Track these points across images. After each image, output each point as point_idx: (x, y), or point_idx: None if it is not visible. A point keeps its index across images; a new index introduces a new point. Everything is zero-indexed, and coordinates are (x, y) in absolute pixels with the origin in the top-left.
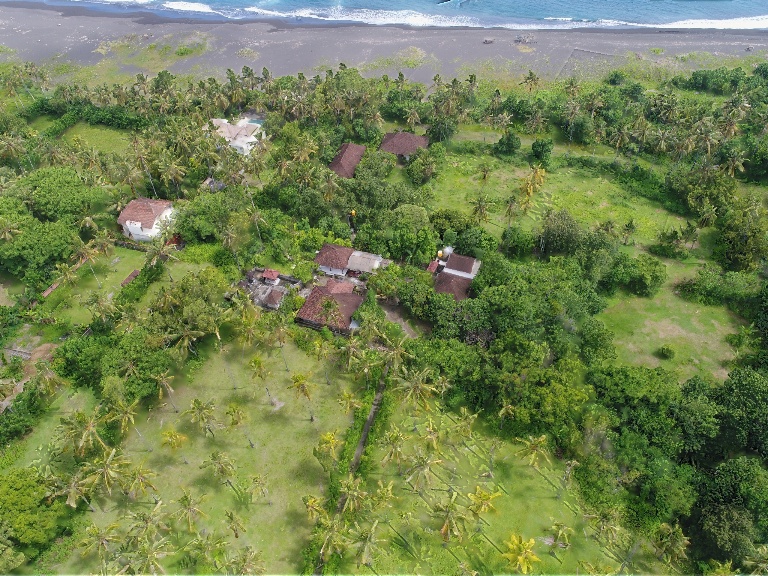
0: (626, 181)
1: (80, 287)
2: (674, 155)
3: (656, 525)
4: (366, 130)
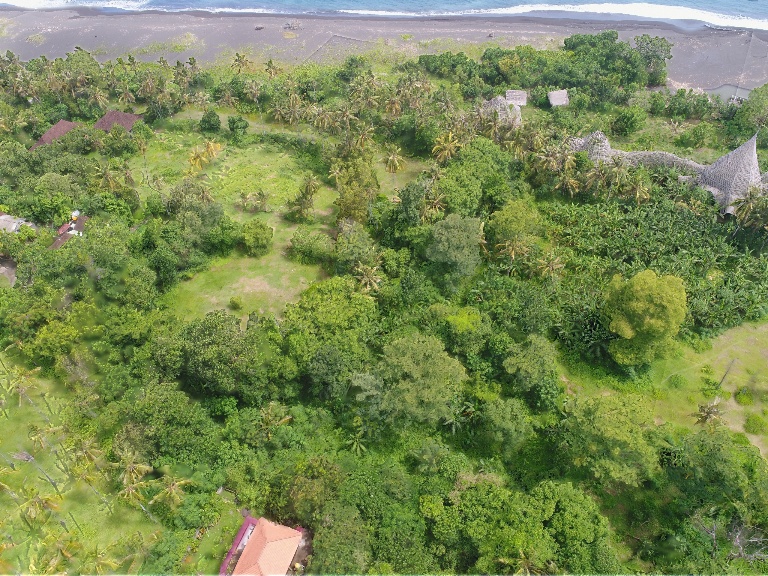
0: (301, 155)
1: None
2: (329, 131)
3: (109, 442)
4: (90, 109)
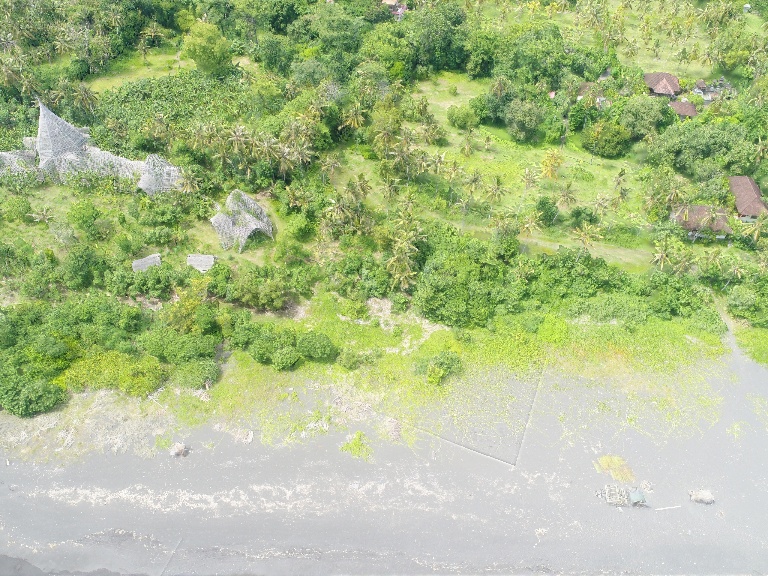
0: None
1: None
2: None
3: None
4: None
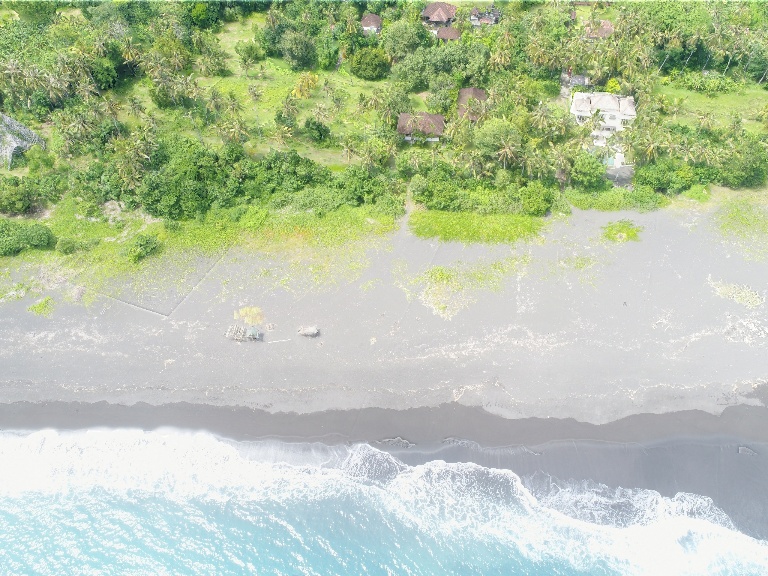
0: None
1: (604, 17)
2: None
3: None
4: None
